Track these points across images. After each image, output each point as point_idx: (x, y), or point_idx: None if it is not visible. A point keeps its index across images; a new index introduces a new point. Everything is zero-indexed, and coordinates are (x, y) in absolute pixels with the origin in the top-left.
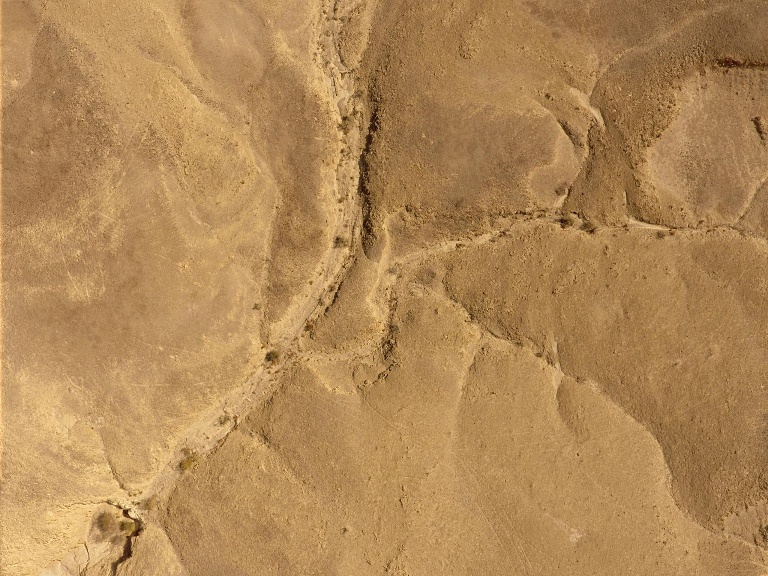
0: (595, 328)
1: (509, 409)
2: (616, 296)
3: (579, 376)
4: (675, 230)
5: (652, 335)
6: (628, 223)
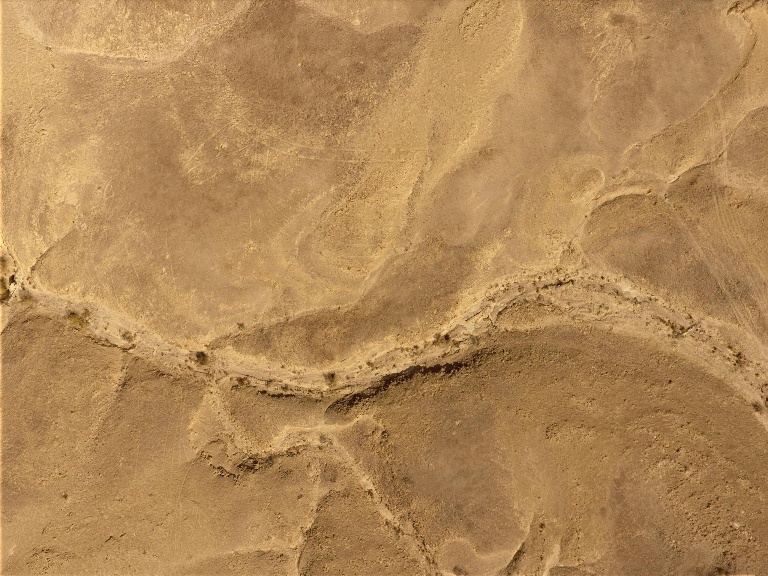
0: None
1: None
2: None
3: None
4: None
5: None
6: None
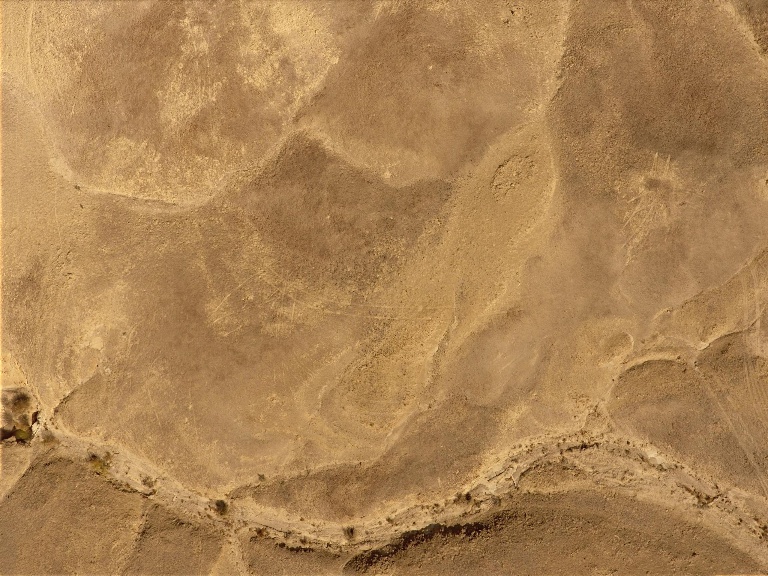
0: None
1: None
2: None
3: None
4: None
5: None
6: None
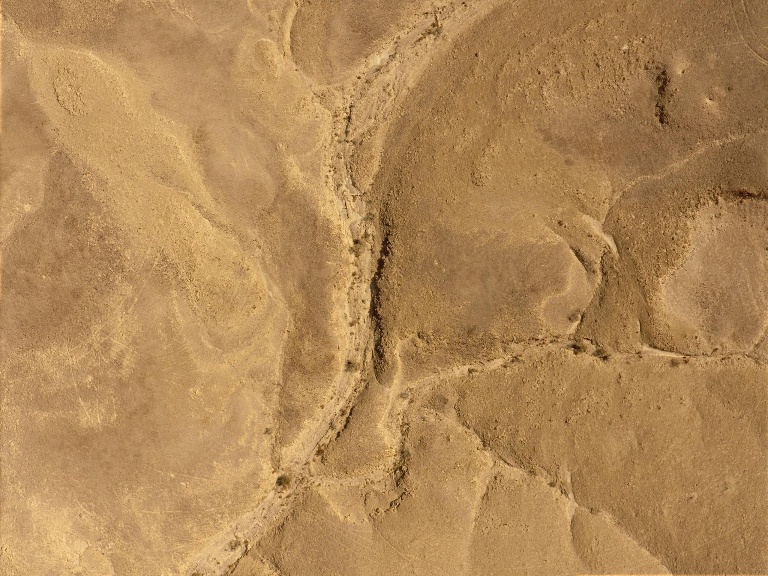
0: (609, 459)
1: (522, 541)
2: (630, 427)
3: (593, 507)
4: (689, 357)
5: (667, 467)
6: (642, 350)
